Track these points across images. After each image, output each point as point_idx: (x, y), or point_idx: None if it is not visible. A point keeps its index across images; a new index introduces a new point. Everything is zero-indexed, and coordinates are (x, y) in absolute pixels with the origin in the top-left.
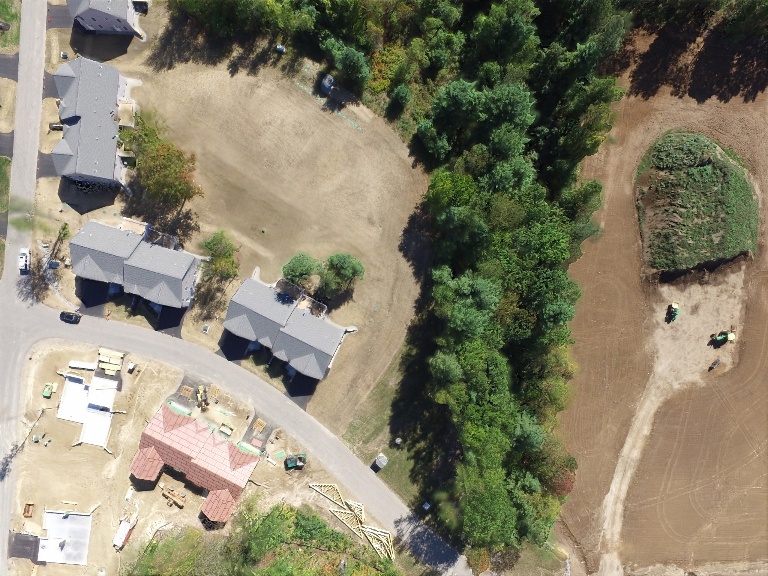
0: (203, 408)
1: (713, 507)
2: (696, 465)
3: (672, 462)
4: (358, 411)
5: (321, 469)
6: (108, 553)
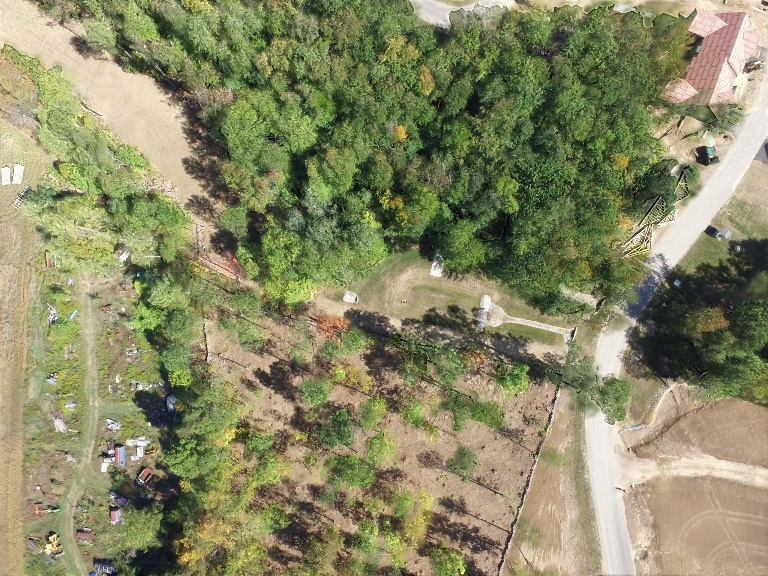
0: (745, 68)
1: (719, 568)
2: (760, 545)
3: (759, 519)
4: (759, 208)
5: (702, 180)
6: (593, 2)
